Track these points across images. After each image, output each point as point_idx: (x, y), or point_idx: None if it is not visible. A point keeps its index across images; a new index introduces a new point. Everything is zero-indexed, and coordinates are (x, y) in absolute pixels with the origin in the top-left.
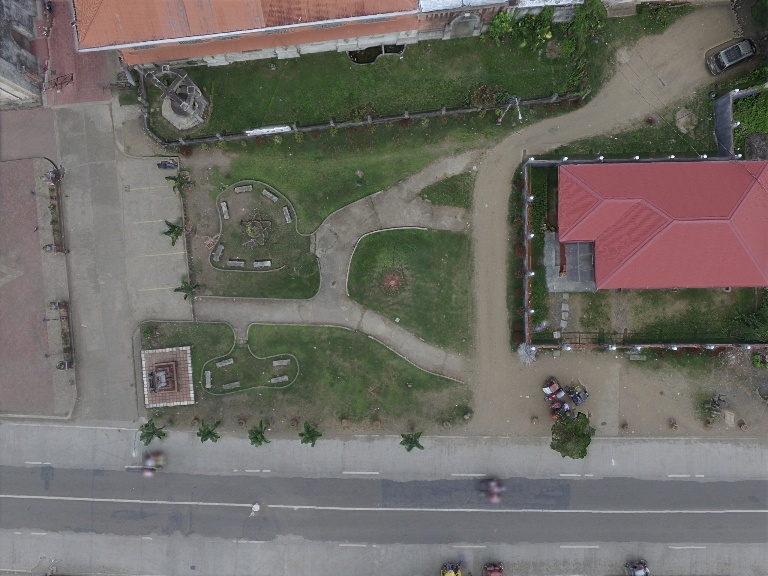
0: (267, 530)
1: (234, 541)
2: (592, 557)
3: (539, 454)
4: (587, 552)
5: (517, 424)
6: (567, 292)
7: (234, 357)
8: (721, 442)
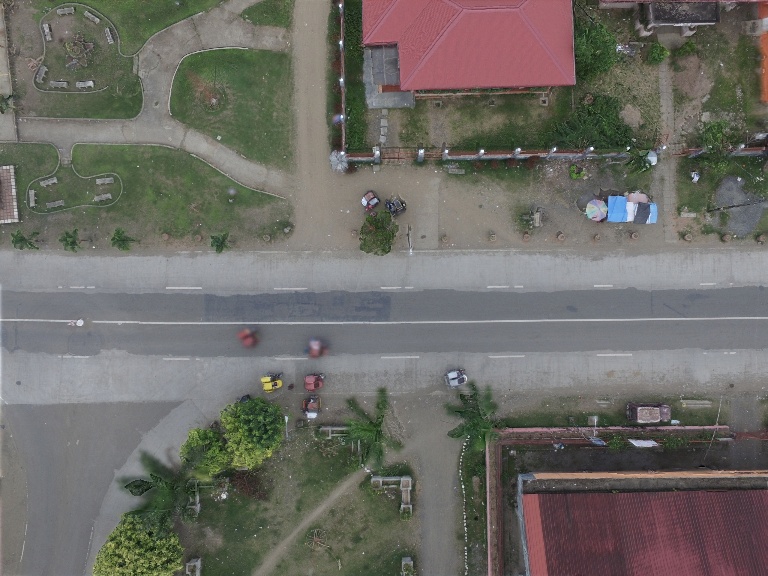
0: (92, 345)
1: (59, 356)
2: (413, 367)
3: (360, 268)
4: (408, 363)
5: (338, 238)
6: (386, 108)
7: (59, 177)
8: (540, 254)
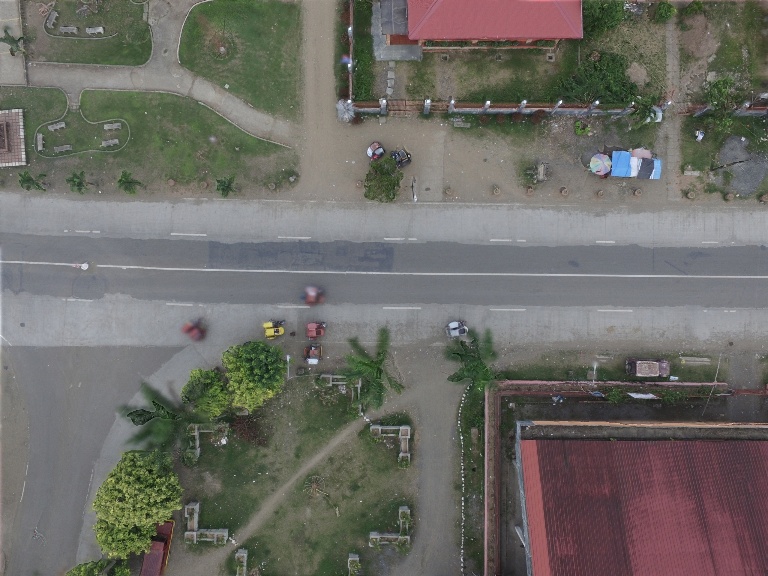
0: (96, 289)
1: (63, 299)
2: (414, 318)
3: (364, 218)
4: (409, 313)
5: (343, 189)
6: (393, 60)
7: (67, 122)
8: (543, 208)
